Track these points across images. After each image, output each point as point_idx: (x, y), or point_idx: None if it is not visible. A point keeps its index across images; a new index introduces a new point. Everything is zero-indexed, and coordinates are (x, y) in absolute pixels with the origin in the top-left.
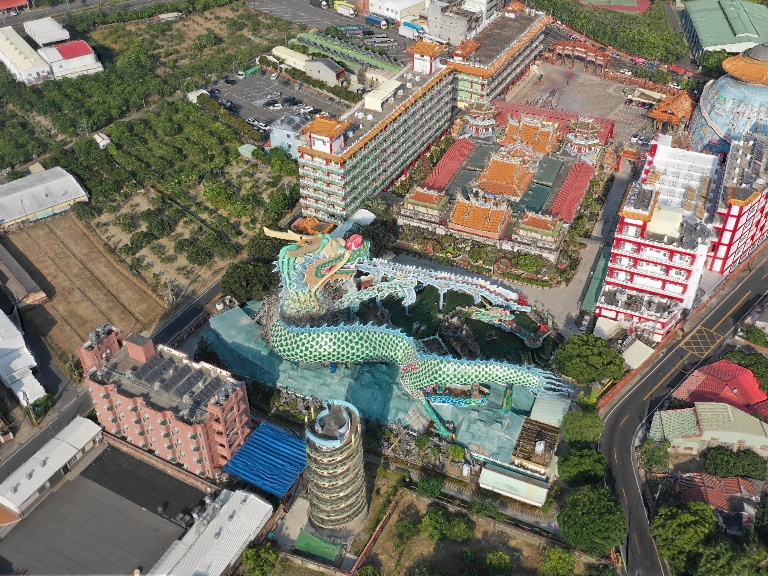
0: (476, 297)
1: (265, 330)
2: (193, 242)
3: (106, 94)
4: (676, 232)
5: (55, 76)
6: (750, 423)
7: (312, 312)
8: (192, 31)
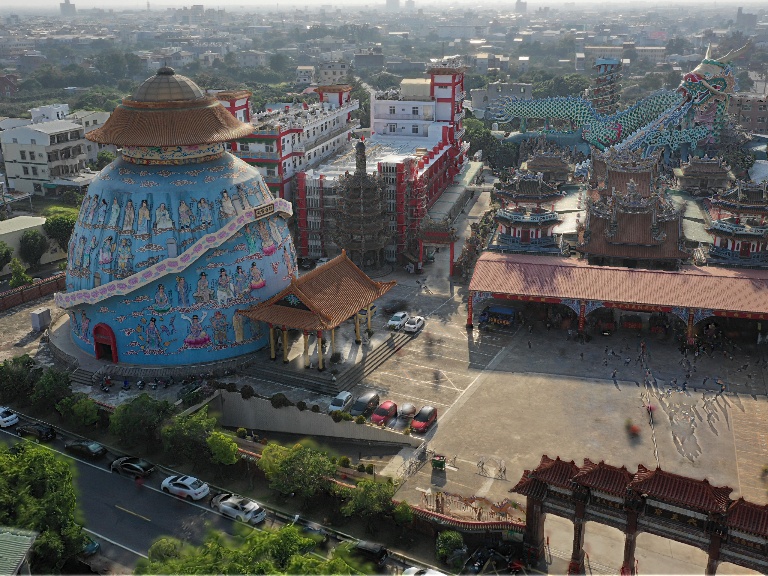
0: None
1: None
2: None
3: None
4: None
5: None
6: None
7: None
8: None
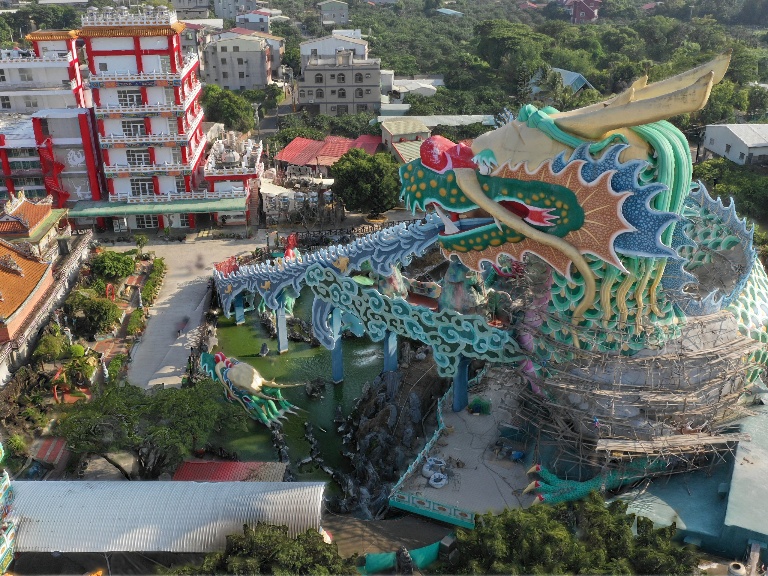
0: (252, 296)
1: (761, 365)
2: None
3: None
4: None
5: None
6: (397, 119)
7: None
8: None
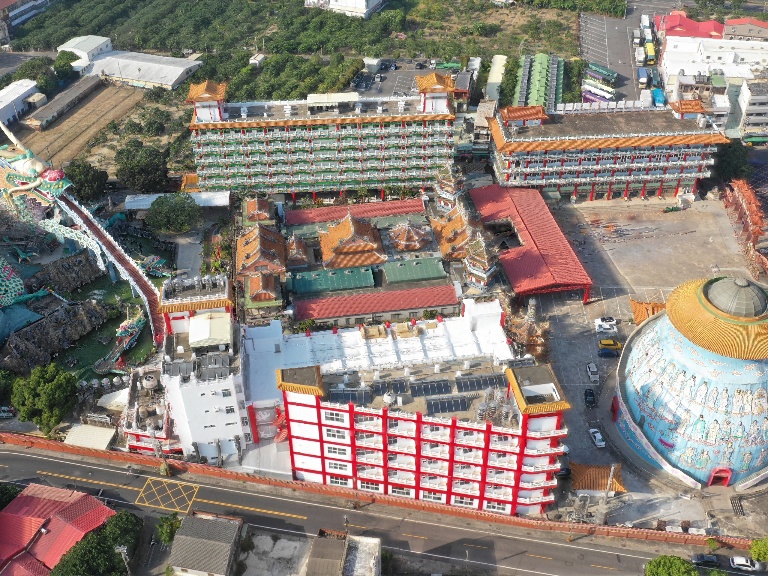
0: None
1: None
2: (140, 146)
3: (329, 33)
4: (192, 351)
5: (328, 7)
6: None
7: (12, 212)
8: (495, 19)
